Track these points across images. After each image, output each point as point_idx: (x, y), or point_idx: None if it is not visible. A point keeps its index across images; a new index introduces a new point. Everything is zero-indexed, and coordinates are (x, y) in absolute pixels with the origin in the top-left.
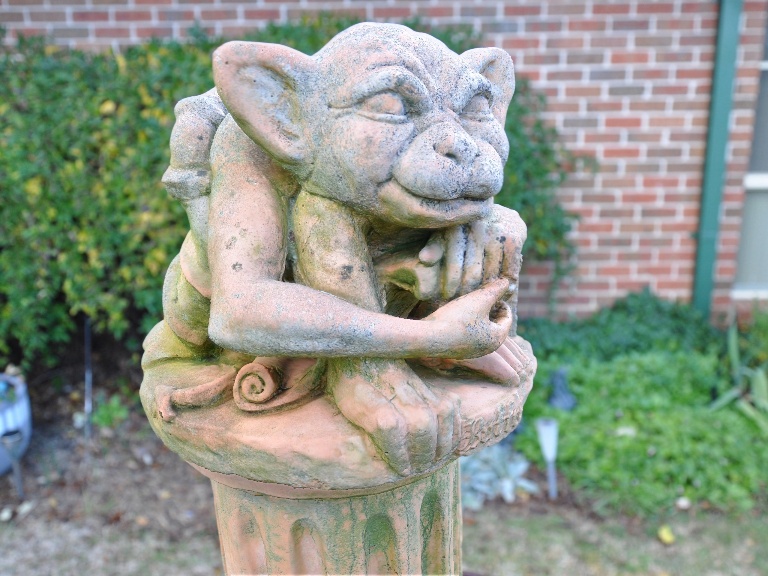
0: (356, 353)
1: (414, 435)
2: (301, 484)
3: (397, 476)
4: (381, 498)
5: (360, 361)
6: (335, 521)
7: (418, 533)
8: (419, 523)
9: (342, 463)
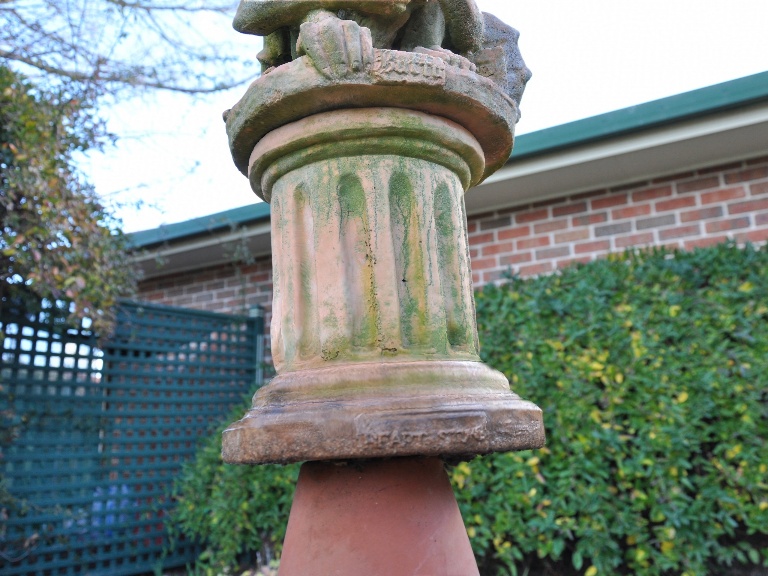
0: None
1: (323, 33)
2: (270, 100)
3: (323, 79)
4: (352, 161)
5: (307, 18)
6: (318, 177)
7: (386, 199)
8: None
9: (289, 73)
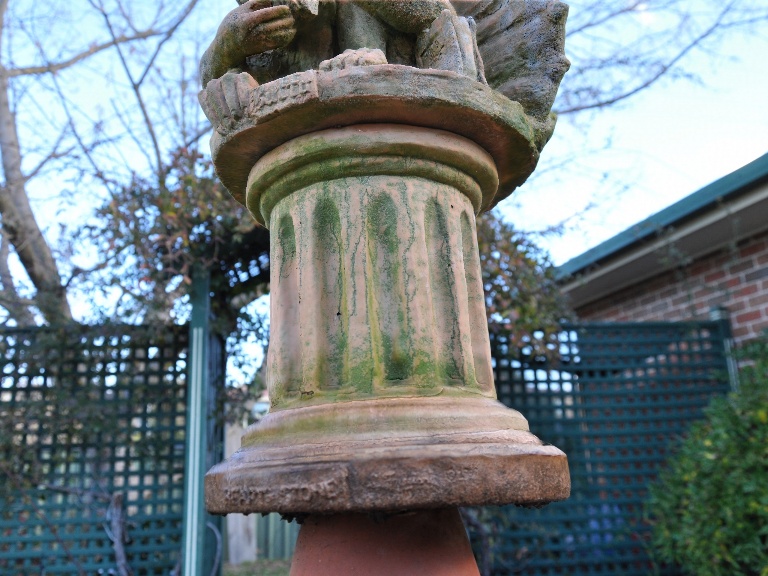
0: (211, 70)
1: None
2: None
3: (222, 137)
4: None
5: None
6: None
7: (310, 232)
8: (315, 226)
9: None
